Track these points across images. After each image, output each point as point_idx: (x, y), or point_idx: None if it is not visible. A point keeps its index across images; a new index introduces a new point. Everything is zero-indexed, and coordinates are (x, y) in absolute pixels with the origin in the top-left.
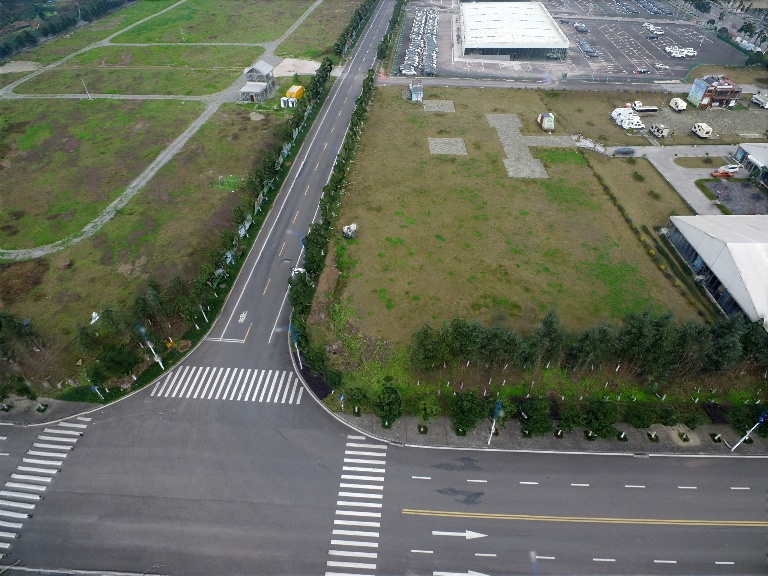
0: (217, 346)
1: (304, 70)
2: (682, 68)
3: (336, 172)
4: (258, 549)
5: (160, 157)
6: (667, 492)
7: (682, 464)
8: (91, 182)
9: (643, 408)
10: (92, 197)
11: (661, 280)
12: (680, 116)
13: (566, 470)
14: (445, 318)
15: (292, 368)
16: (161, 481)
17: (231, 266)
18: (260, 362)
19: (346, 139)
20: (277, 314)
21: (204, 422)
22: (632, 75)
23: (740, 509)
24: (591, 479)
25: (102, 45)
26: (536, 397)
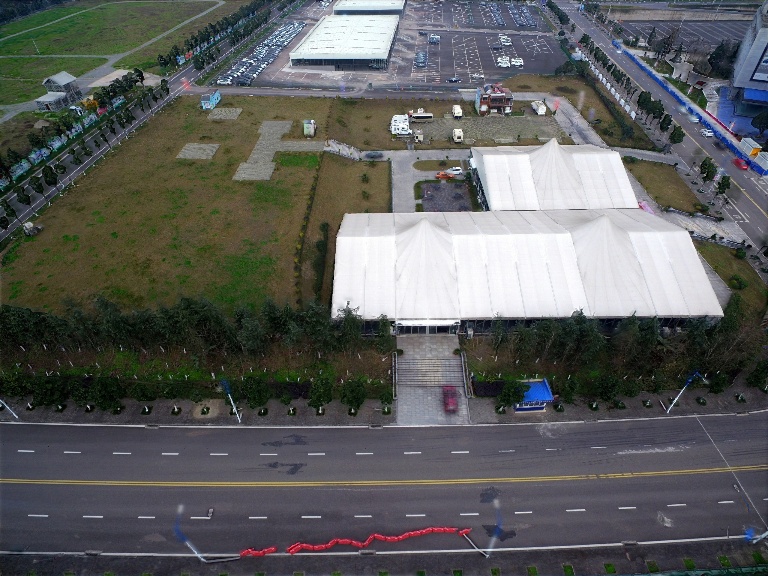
0: None
1: None
2: (499, 77)
3: (44, 175)
4: None
5: None
6: (147, 458)
7: (183, 434)
8: None
9: (185, 385)
10: None
11: (288, 272)
12: (455, 122)
13: (70, 440)
14: (55, 307)
15: None
16: None
17: None
18: None
19: None
20: None
21: None
22: (443, 84)
23: (202, 472)
24: (87, 447)
25: None
26: (96, 377)
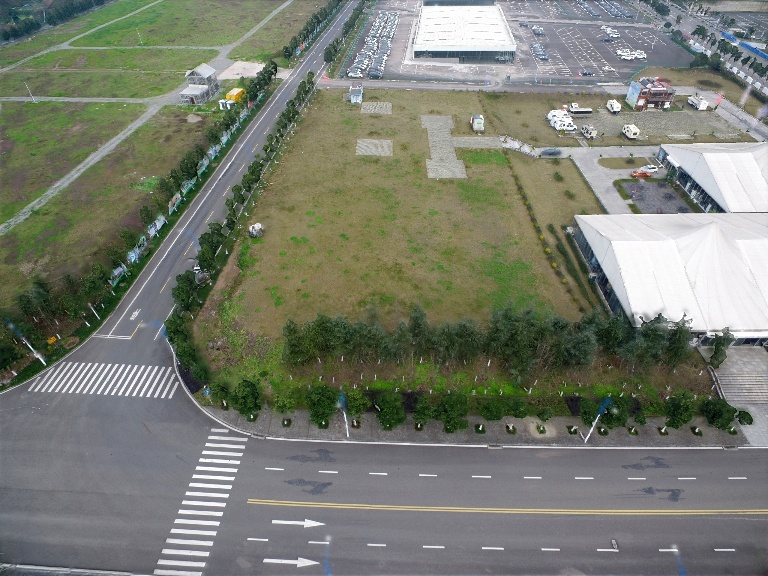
0: (103, 343)
1: (252, 73)
2: (629, 70)
3: (250, 173)
4: (98, 538)
5: (89, 158)
6: (511, 482)
7: (533, 455)
8: (15, 183)
9: (507, 401)
10: (12, 198)
11: (551, 277)
12: (615, 118)
13: (418, 461)
14: (329, 315)
15: (172, 364)
16: (19, 473)
17: (135, 265)
18: (142, 358)
19: (267, 140)
20: (169, 311)
21: (74, 416)
22: (577, 77)
23: (579, 498)
24: (440, 470)
25: (60, 48)
26: (405, 391)
